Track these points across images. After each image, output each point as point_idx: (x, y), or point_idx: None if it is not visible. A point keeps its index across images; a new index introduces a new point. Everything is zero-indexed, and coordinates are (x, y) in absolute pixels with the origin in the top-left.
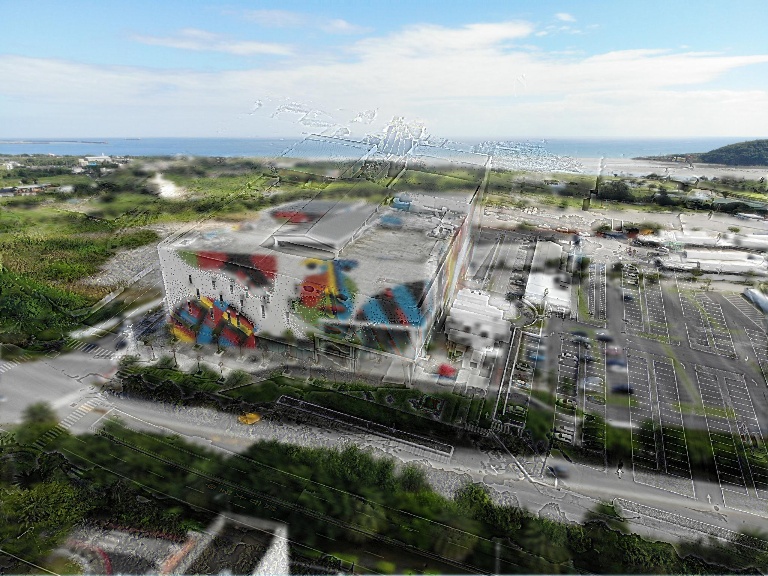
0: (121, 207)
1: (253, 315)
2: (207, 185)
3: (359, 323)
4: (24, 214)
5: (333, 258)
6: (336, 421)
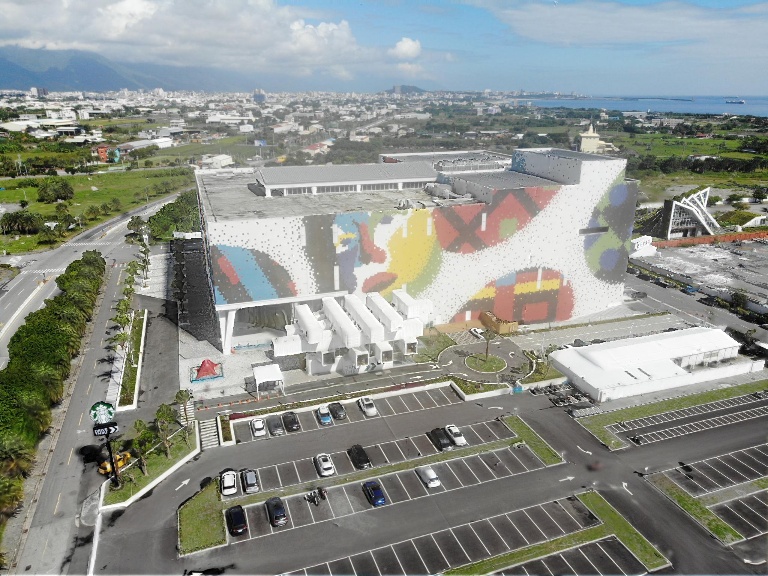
0: None
1: None
2: None
3: None
4: None
5: None
6: None
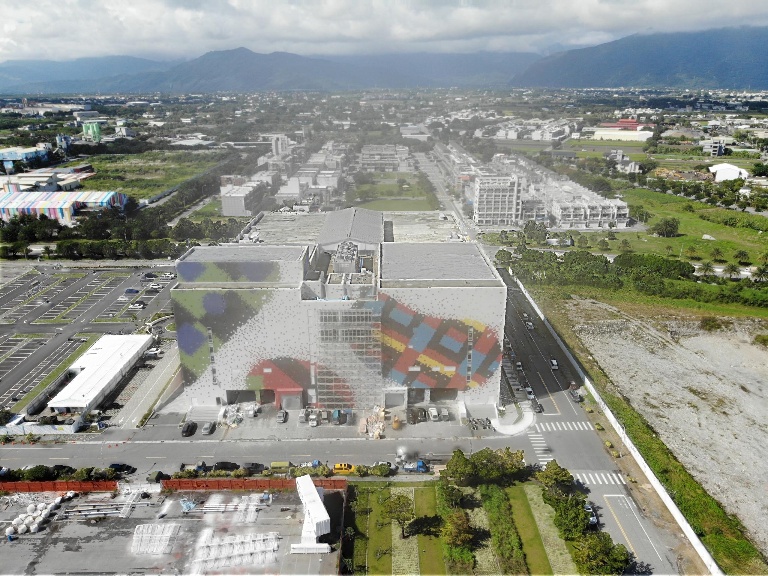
0: (721, 355)
1: None
2: (731, 424)
3: None
4: (740, 308)
5: None
6: None
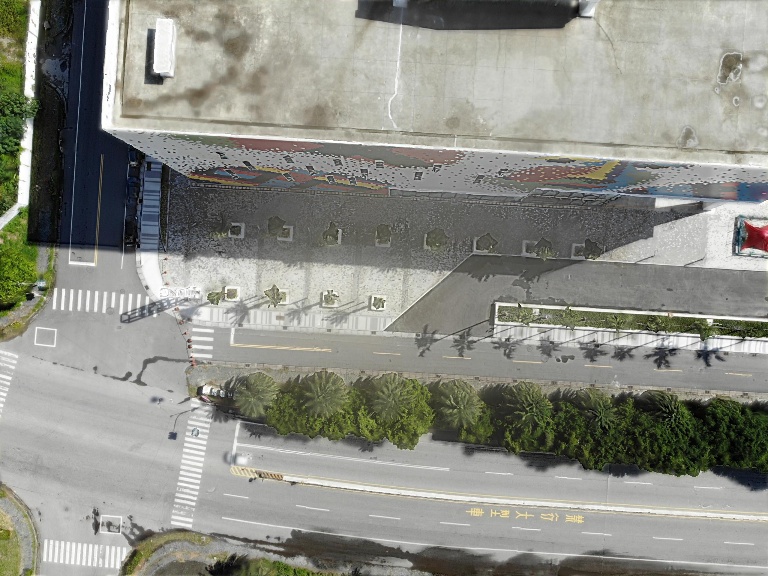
0: None
1: (391, 178)
2: None
3: (666, 182)
4: None
5: (574, 6)
6: (609, 331)
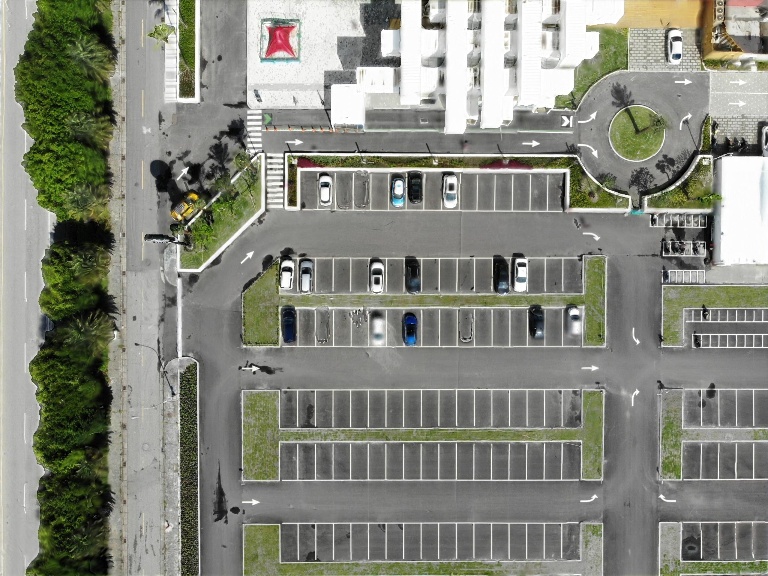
0: None
1: None
2: None
3: None
4: None
5: None
6: None
